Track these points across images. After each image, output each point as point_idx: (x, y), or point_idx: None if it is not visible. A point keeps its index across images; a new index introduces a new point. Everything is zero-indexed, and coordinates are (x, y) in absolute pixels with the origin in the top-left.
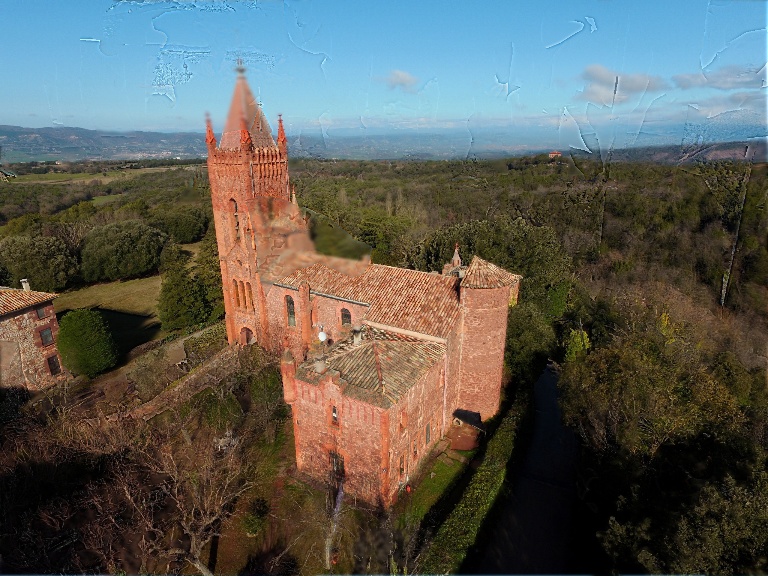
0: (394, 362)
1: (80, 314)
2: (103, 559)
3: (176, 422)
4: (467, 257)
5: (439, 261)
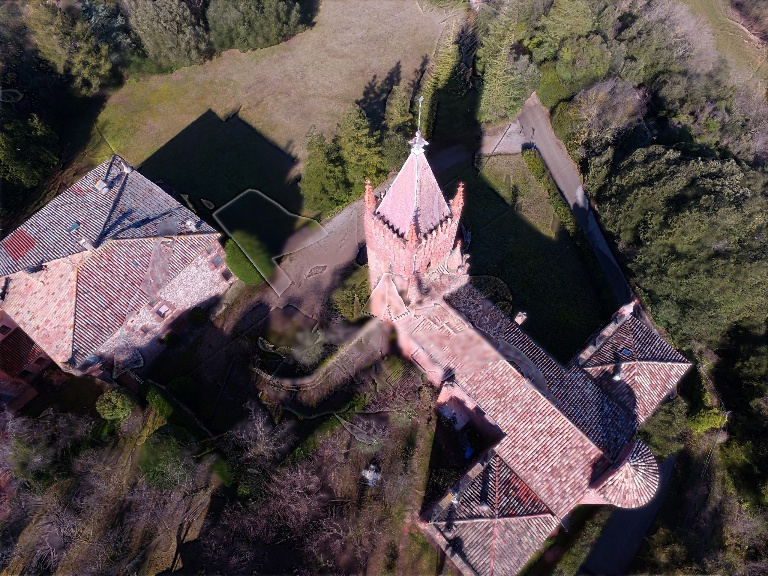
0: (507, 546)
1: None
2: (304, 574)
3: (337, 462)
4: (654, 238)
5: (619, 209)
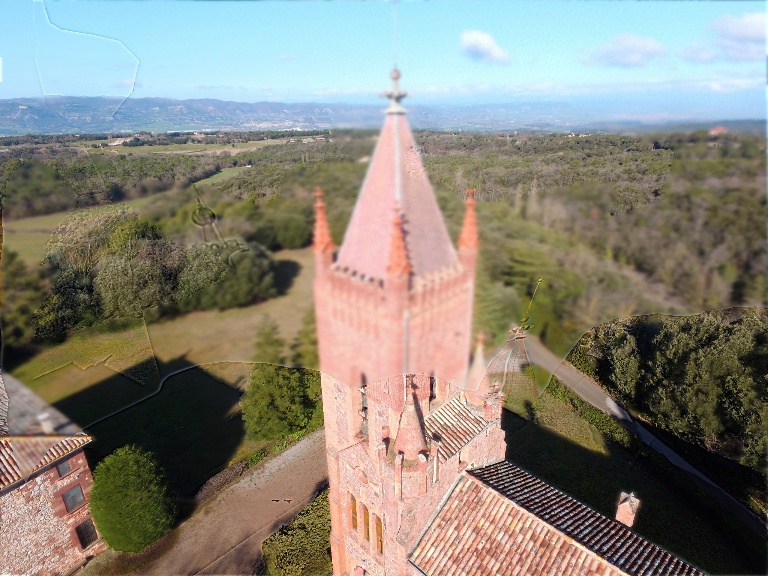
0: None
1: (122, 464)
2: None
3: None
4: (757, 407)
5: (681, 388)
